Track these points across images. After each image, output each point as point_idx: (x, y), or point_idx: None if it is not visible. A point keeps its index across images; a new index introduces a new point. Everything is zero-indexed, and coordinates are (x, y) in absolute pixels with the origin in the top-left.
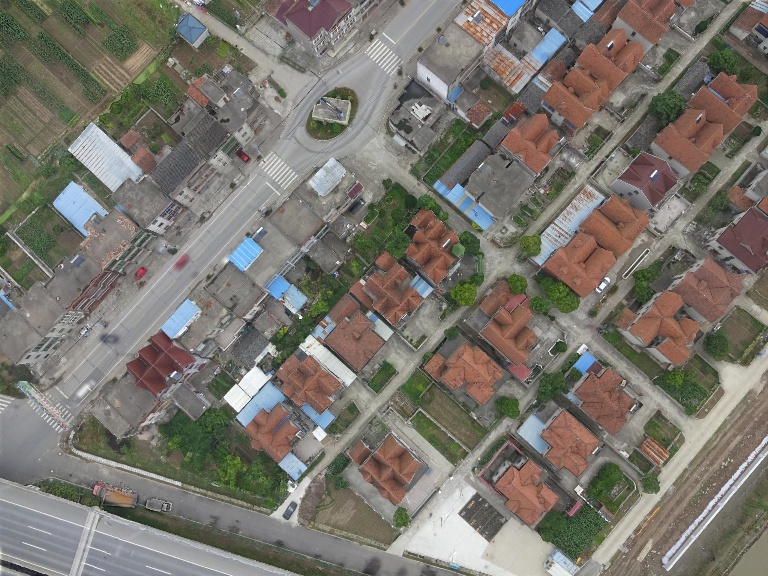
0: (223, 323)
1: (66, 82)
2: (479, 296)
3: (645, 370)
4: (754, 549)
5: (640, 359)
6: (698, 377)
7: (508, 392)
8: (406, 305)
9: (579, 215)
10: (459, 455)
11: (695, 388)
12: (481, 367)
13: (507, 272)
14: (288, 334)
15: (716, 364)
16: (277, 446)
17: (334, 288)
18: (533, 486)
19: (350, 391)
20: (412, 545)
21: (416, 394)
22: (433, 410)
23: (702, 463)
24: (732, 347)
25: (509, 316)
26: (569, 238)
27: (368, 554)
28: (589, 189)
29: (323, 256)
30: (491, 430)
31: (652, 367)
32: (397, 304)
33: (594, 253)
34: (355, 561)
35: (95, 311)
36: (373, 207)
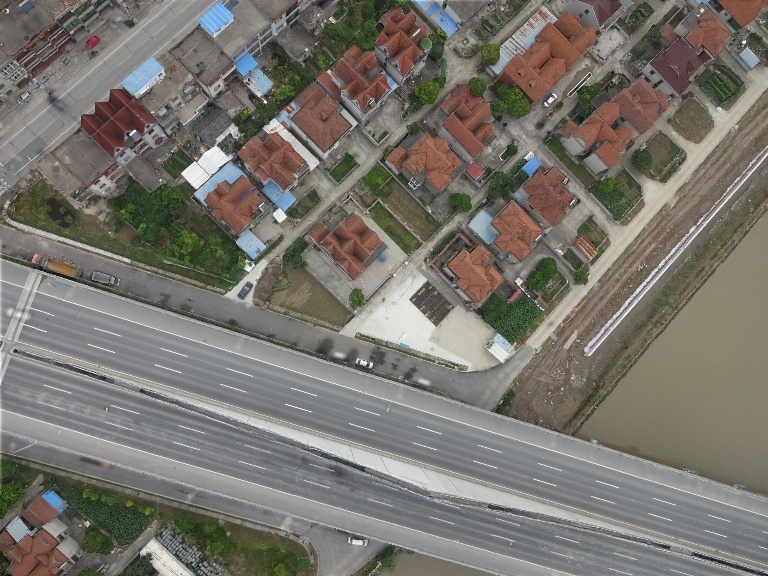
0: (186, 93)
1: None
2: (439, 100)
3: (581, 180)
4: (659, 340)
5: (578, 170)
6: (625, 190)
7: (461, 191)
8: (374, 90)
9: (534, 32)
10: (413, 246)
11: (622, 198)
12: (442, 154)
13: (466, 81)
14: (251, 119)
15: (640, 179)
16: (240, 214)
17: (301, 74)
18: (482, 267)
19: (311, 179)
20: (364, 327)
21: (376, 186)
22: (391, 203)
23: (623, 265)
24: (654, 166)
25: (470, 110)
26: (524, 52)
27: (321, 335)
28: (544, 10)
29: (291, 43)
30: (444, 223)
31: (587, 178)
32: (366, 87)
33: (547, 62)
34: (308, 341)
35: (38, 77)
36: (342, 4)
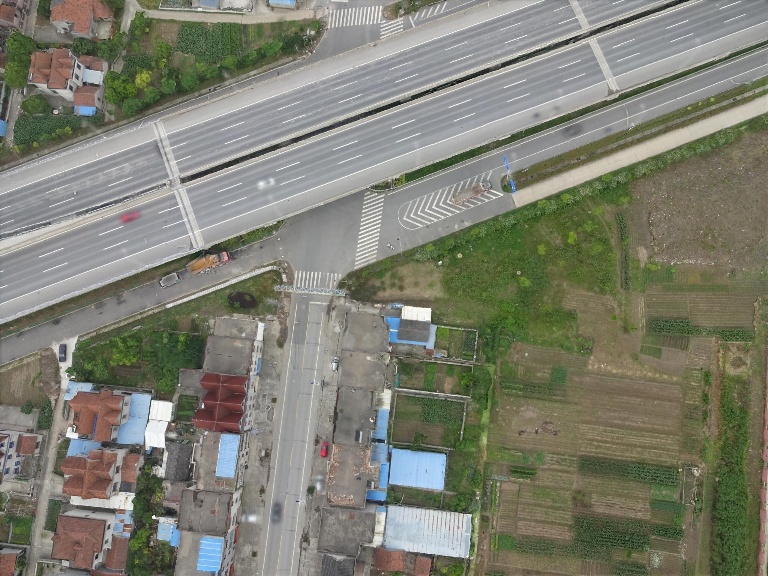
0: None
1: (532, 574)
2: None
3: None
4: None
5: None
6: None
7: None
8: None
9: None
10: None
11: None
12: None
13: None
14: None
15: None
16: None
17: (136, 567)
18: None
19: None
20: None
21: (17, 523)
22: None
23: None
24: None
25: None
26: None
27: None
28: None
29: None
30: None
31: None
32: None
33: None
34: None
35: None
36: None
